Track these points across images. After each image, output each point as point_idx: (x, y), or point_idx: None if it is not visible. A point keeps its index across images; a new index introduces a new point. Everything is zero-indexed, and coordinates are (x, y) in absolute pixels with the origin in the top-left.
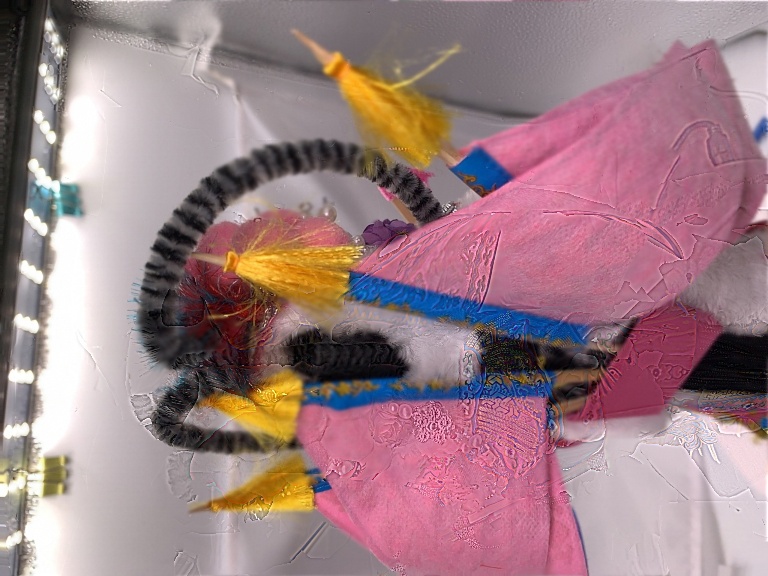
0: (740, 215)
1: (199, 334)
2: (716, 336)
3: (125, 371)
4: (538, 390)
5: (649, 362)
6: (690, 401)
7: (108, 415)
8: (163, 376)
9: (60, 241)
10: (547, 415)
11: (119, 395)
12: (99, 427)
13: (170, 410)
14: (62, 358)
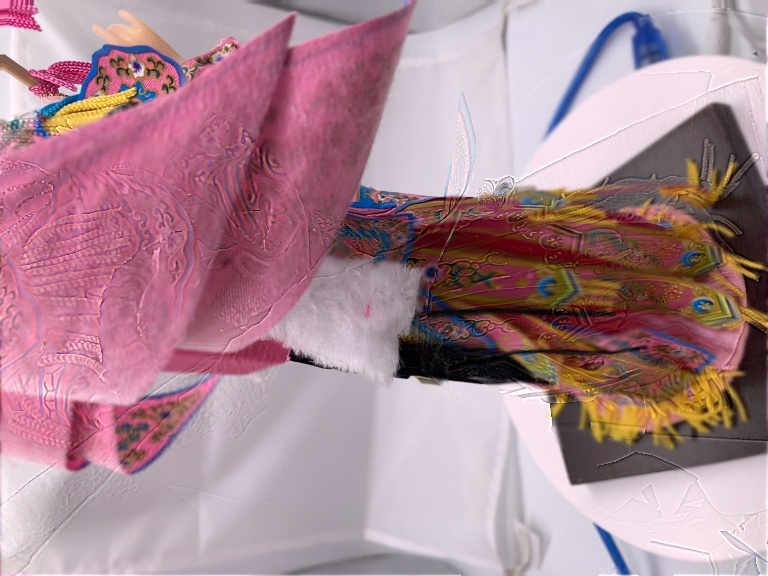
0: (552, 419)
1: None
2: None
3: None
4: None
5: None
6: None
7: None
8: None
9: None
10: None
11: None
12: None
13: None
14: None
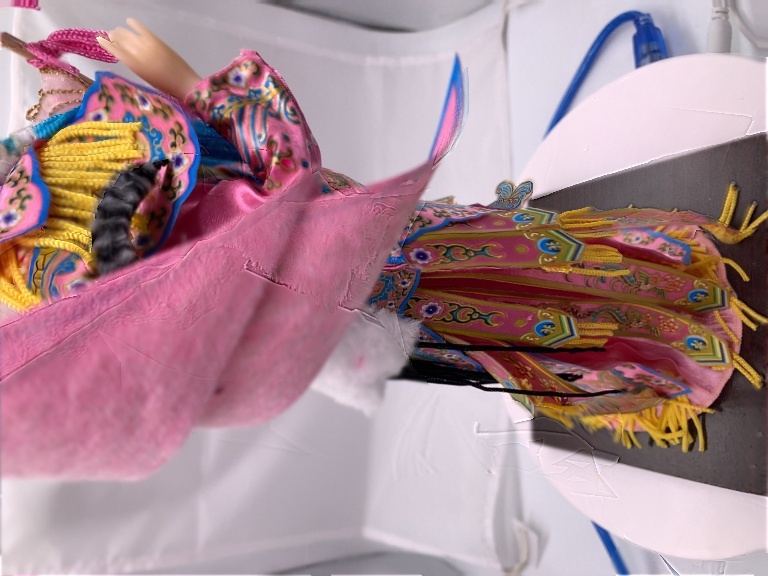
0: None
1: None
2: None
3: None
4: None
5: None
6: None
7: None
8: None
9: None
10: None
11: None
12: None
13: None
14: None
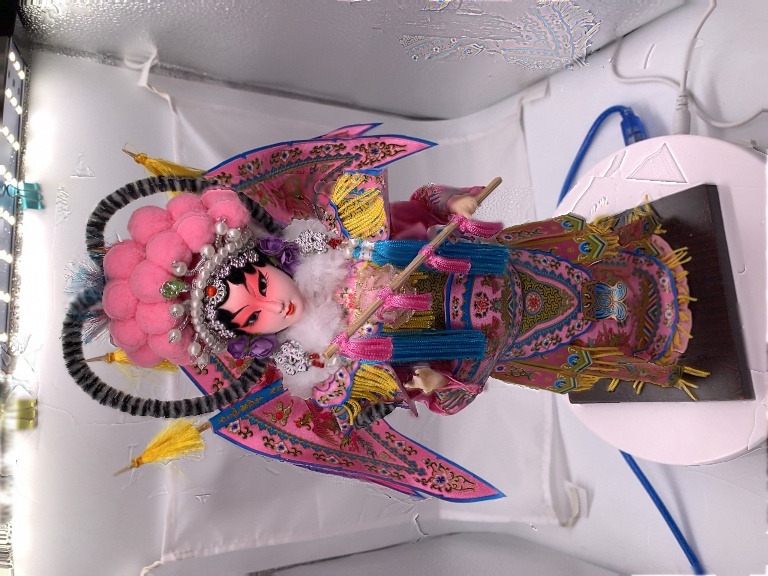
0: None
1: (96, 183)
2: (364, 6)
3: (55, 312)
4: (367, 180)
5: (326, 6)
6: (557, 251)
7: (52, 480)
8: (79, 250)
9: (10, 406)
10: (380, 183)
11: (53, 356)
12: (42, 492)
13: (96, 325)
14: (5, 454)
